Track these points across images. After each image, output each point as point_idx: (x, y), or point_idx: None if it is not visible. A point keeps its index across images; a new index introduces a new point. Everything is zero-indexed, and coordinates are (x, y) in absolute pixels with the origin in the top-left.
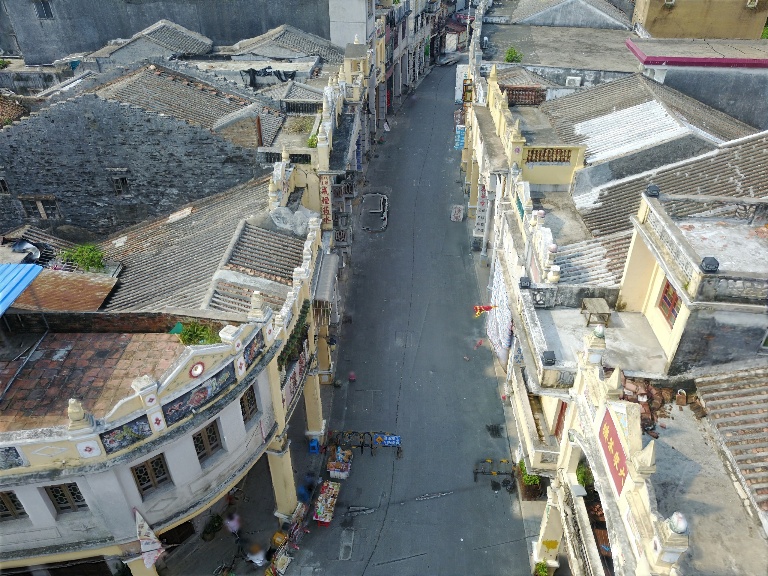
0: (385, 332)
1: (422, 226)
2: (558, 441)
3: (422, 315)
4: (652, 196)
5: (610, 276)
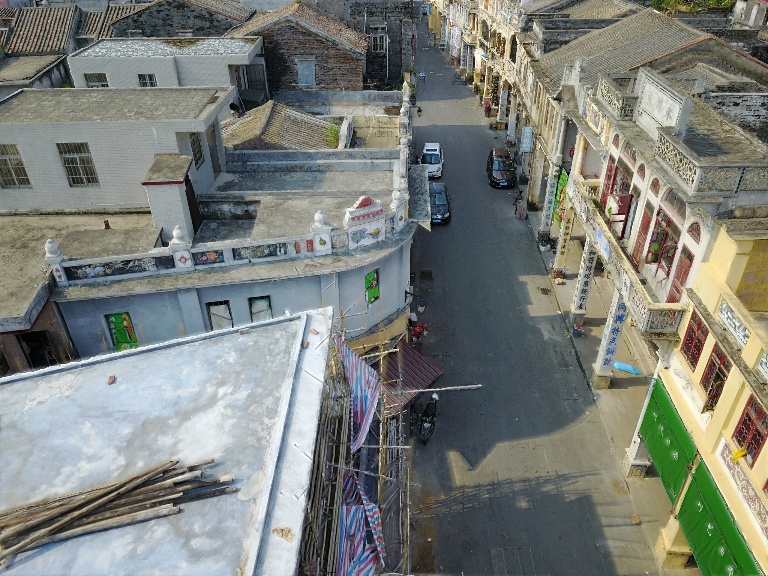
0: None
1: None
2: None
3: (423, 63)
4: None
5: None
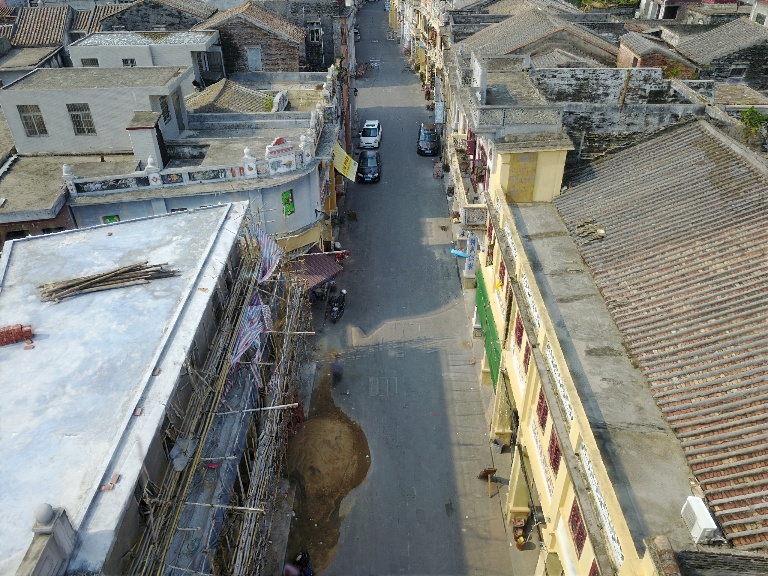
0: None
1: None
2: None
3: None
4: None
5: None
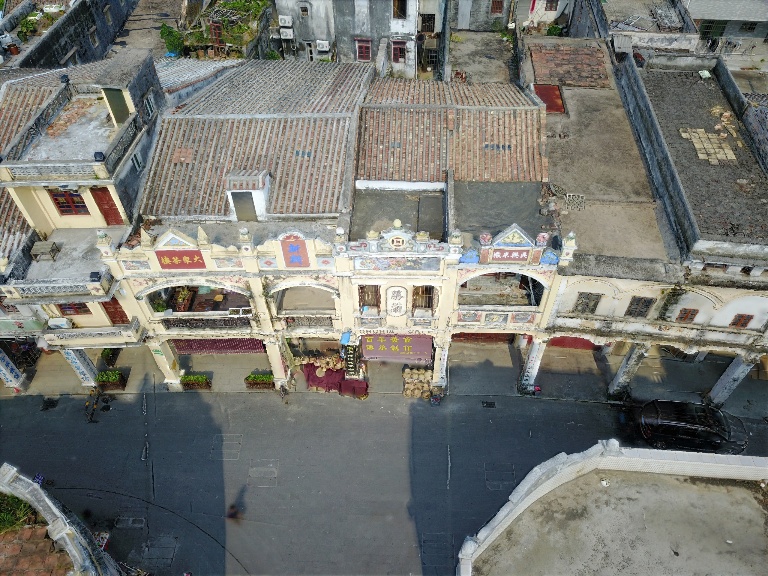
0: None
1: None
2: (120, 324)
3: None
4: (1, 161)
5: (3, 236)
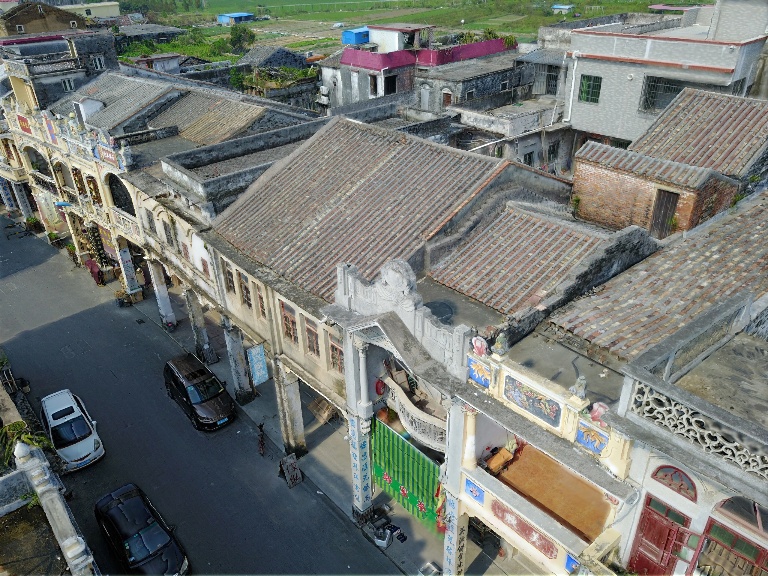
0: None
1: None
2: None
3: None
4: None
5: None
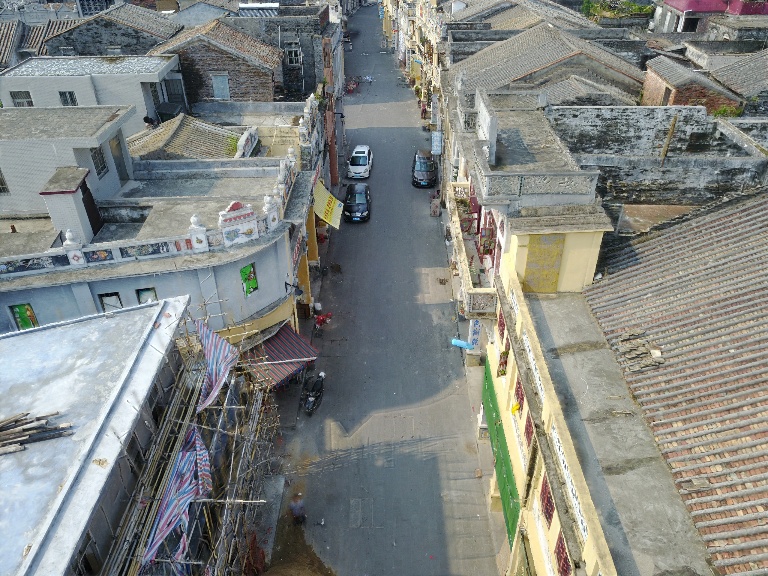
0: (359, 69)
1: (368, 50)
2: None
3: (373, 66)
4: None
5: None
